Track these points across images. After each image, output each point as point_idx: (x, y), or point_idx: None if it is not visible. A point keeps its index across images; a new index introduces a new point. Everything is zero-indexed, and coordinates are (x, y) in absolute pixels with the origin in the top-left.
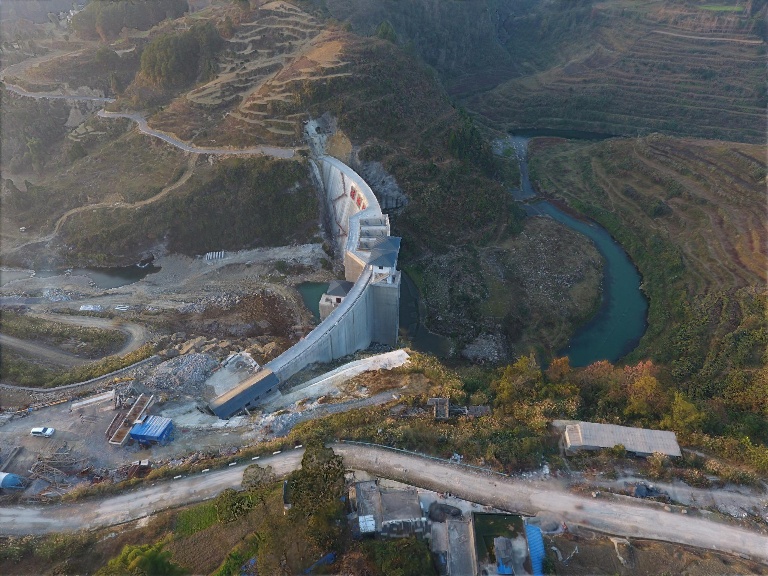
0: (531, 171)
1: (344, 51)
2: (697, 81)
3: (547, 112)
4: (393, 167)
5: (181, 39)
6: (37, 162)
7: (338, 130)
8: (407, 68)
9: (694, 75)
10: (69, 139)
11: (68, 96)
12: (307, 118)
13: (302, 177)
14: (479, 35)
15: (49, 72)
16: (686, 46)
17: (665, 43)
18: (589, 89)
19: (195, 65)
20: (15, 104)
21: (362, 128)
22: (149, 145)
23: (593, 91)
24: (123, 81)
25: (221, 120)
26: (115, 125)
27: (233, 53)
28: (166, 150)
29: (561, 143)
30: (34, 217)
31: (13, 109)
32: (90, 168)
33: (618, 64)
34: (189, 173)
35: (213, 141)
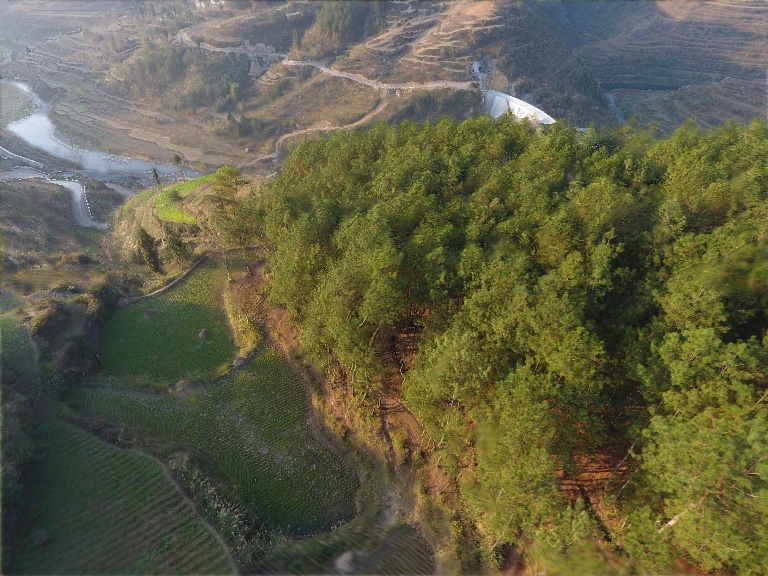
0: (625, 112)
1: (497, 8)
2: (747, 42)
3: (622, 70)
4: (540, 98)
5: (355, 1)
6: (243, 101)
7: (496, 69)
8: (540, 23)
9: (744, 37)
10: (263, 83)
11: (248, 51)
12: (472, 60)
13: (477, 103)
14: (548, 9)
15: (233, 31)
16: (735, 14)
17: (717, 12)
18: (657, 50)
19: (362, 23)
20: (209, 57)
21: (515, 67)
22: (341, 84)
23: (660, 52)
24: (290, 39)
25: (398, 64)
26: (303, 71)
27: (398, 12)
28: (357, 87)
29: (640, 93)
30: (253, 142)
31: (207, 61)
32: (293, 103)
33: (679, 29)
34: (383, 103)
35: (396, 79)
